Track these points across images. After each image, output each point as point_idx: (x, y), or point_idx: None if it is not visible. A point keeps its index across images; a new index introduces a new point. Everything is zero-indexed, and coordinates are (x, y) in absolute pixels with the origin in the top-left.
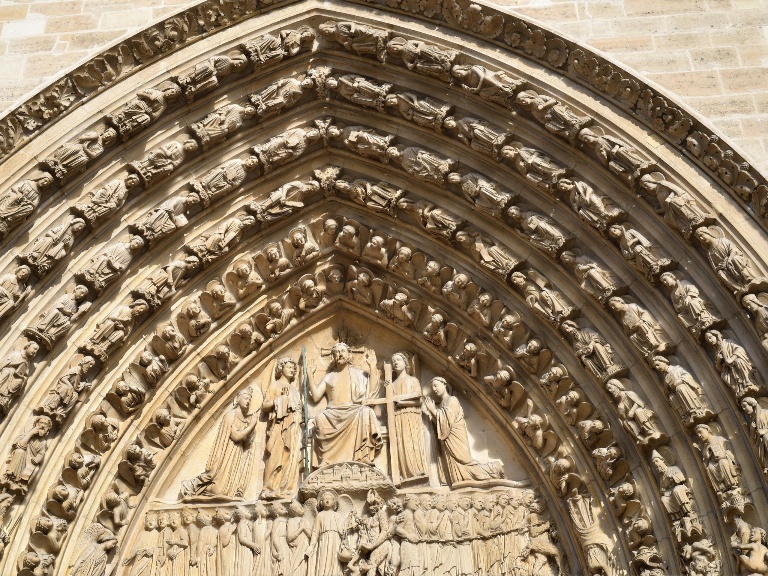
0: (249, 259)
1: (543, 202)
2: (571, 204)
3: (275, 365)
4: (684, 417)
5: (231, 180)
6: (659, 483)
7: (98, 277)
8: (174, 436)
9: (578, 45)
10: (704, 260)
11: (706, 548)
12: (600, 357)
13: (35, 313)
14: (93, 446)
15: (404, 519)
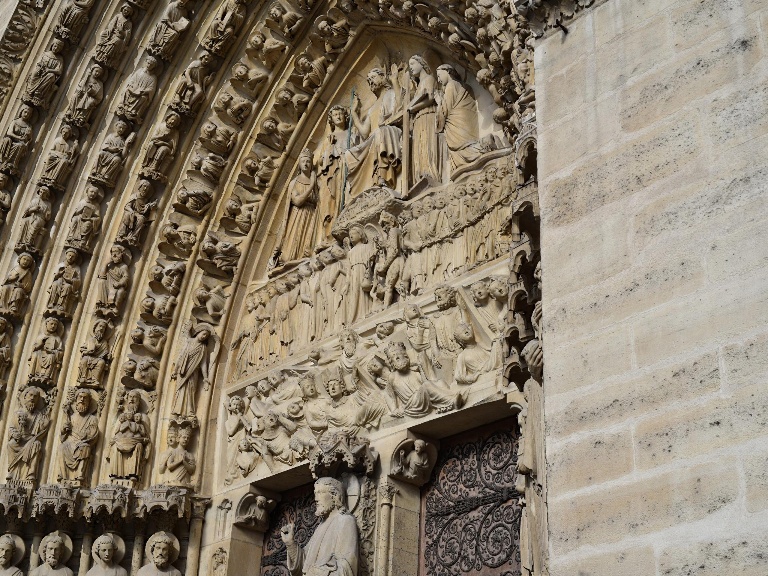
0: None
1: None
2: None
3: None
4: None
5: None
6: None
7: (128, 108)
8: (250, 221)
9: None
10: None
11: None
12: None
13: (94, 161)
14: (177, 255)
15: (407, 230)
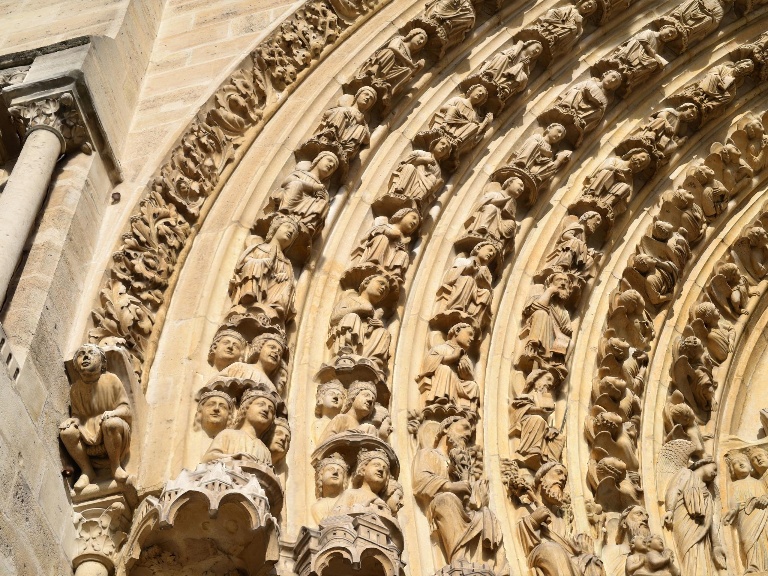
0: (755, 118)
1: None
2: None
3: None
4: None
5: (711, 10)
6: None
7: None
8: (728, 346)
9: None
10: None
11: None
12: None
13: (500, 156)
14: None
15: None
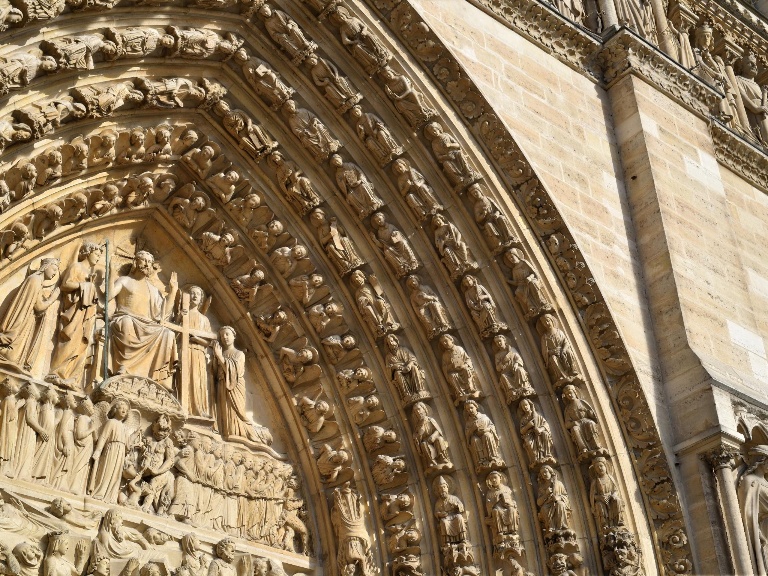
0: (116, 132)
1: (407, 222)
2: (431, 237)
3: (80, 245)
4: (483, 460)
5: None
6: (434, 505)
7: (6, 81)
8: None
9: (494, 111)
10: (534, 339)
11: (477, 575)
12: (416, 379)
13: None
14: None
15: (189, 455)
